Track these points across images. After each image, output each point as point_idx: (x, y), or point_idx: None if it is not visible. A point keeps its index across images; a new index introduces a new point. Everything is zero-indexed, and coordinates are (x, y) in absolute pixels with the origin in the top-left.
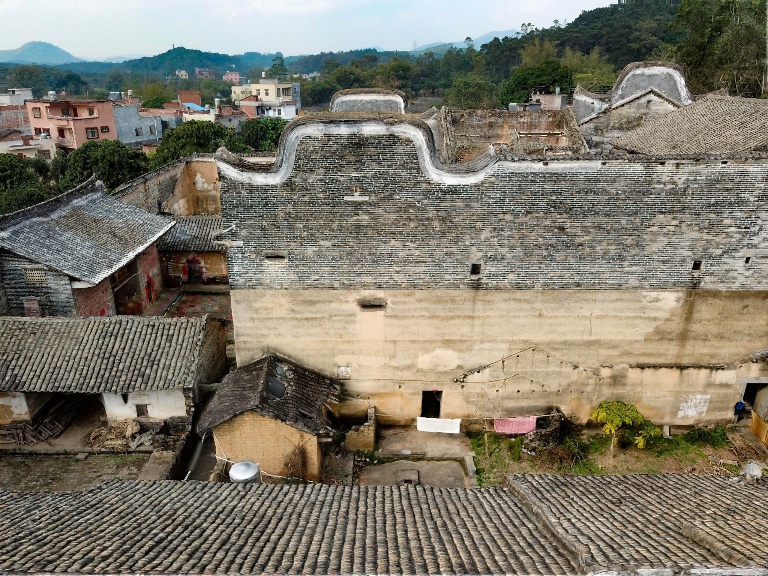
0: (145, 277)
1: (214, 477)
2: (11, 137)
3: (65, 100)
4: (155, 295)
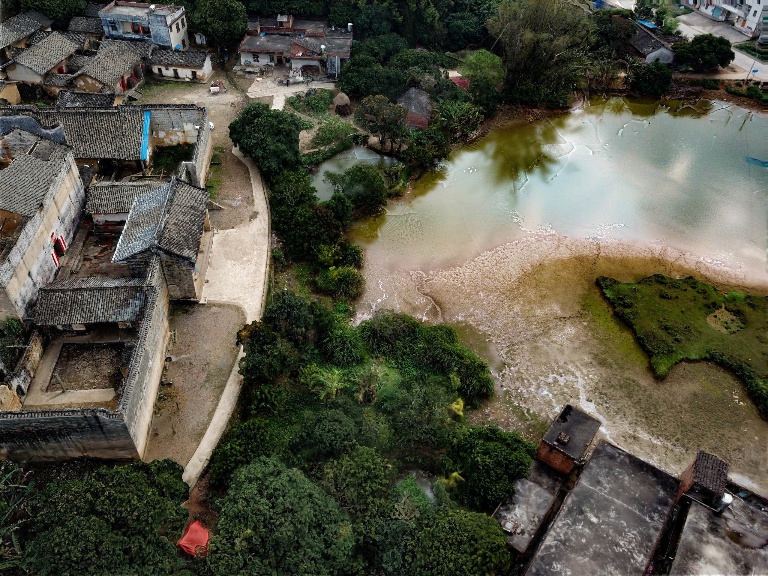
0: None
1: (95, 174)
2: None
3: None
4: None
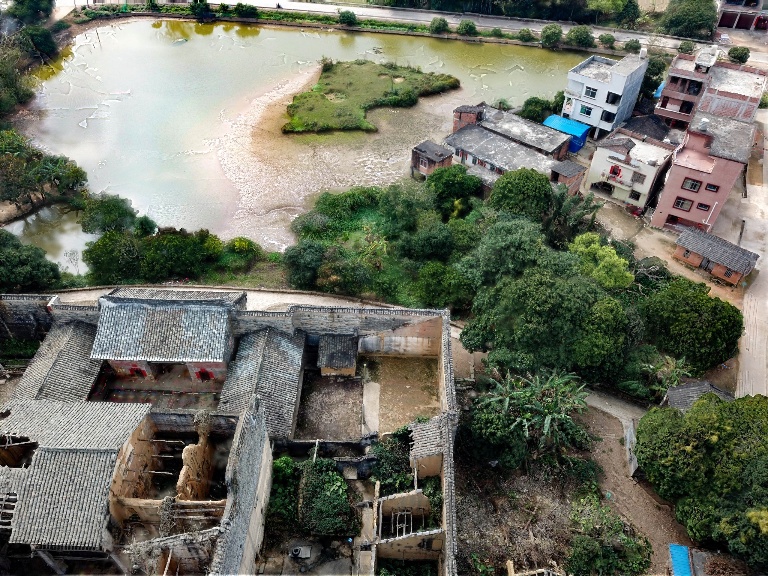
0: (196, 369)
1: None
2: (617, 149)
3: (725, 131)
4: (215, 380)
